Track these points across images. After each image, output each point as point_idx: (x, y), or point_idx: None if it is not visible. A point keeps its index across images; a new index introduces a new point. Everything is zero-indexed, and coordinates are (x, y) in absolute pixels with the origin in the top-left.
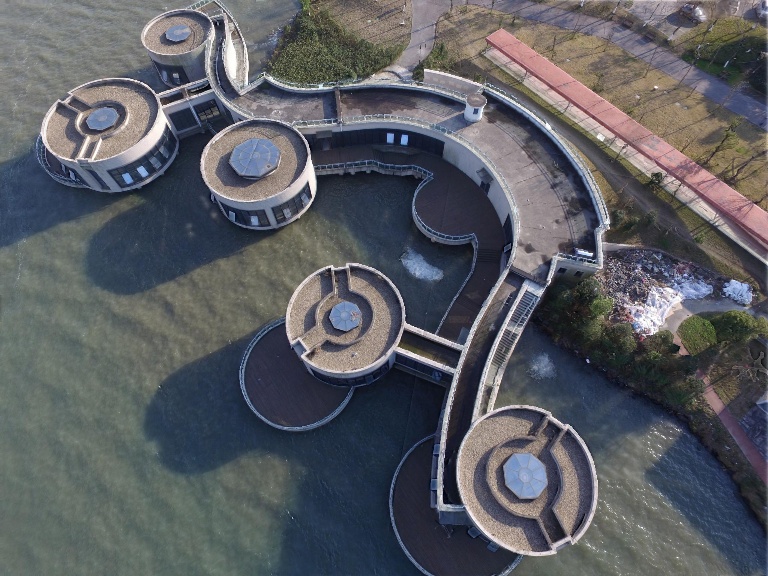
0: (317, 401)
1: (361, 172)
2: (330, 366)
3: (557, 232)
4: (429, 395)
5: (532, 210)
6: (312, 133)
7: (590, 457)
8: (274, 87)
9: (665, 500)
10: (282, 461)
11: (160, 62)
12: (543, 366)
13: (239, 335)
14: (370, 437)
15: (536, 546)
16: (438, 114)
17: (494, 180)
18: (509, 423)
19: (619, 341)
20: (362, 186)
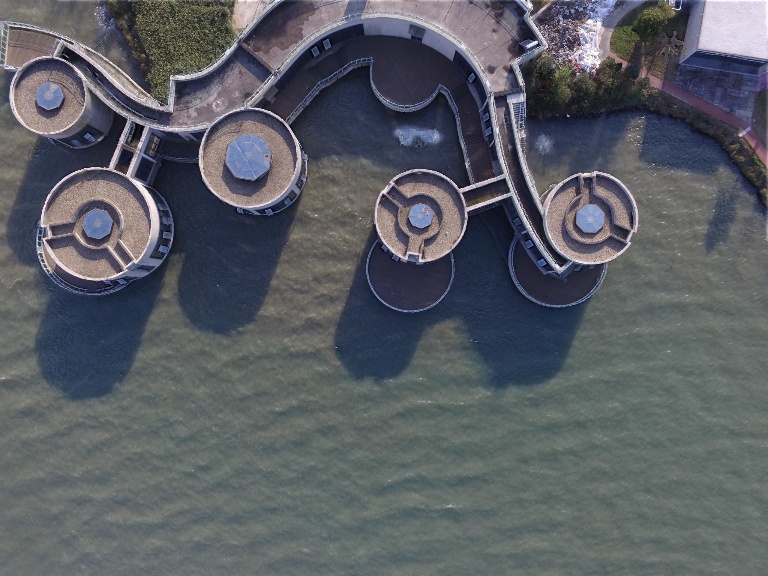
0: (436, 276)
1: (314, 98)
2: (439, 252)
3: (500, 40)
4: (495, 217)
5: (471, 35)
6: (260, 99)
7: (617, 180)
8: (188, 82)
9: (657, 166)
10: (445, 322)
11: (66, 136)
12: (544, 142)
13: (350, 281)
14: (480, 268)
15: (618, 248)
16: (338, 0)
17: (426, 30)
18: (562, 198)
19: (583, 89)
20: (323, 108)
